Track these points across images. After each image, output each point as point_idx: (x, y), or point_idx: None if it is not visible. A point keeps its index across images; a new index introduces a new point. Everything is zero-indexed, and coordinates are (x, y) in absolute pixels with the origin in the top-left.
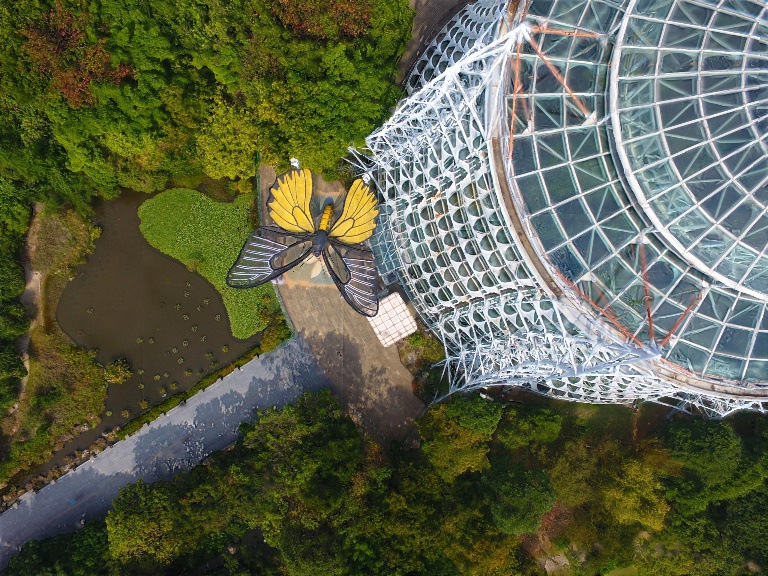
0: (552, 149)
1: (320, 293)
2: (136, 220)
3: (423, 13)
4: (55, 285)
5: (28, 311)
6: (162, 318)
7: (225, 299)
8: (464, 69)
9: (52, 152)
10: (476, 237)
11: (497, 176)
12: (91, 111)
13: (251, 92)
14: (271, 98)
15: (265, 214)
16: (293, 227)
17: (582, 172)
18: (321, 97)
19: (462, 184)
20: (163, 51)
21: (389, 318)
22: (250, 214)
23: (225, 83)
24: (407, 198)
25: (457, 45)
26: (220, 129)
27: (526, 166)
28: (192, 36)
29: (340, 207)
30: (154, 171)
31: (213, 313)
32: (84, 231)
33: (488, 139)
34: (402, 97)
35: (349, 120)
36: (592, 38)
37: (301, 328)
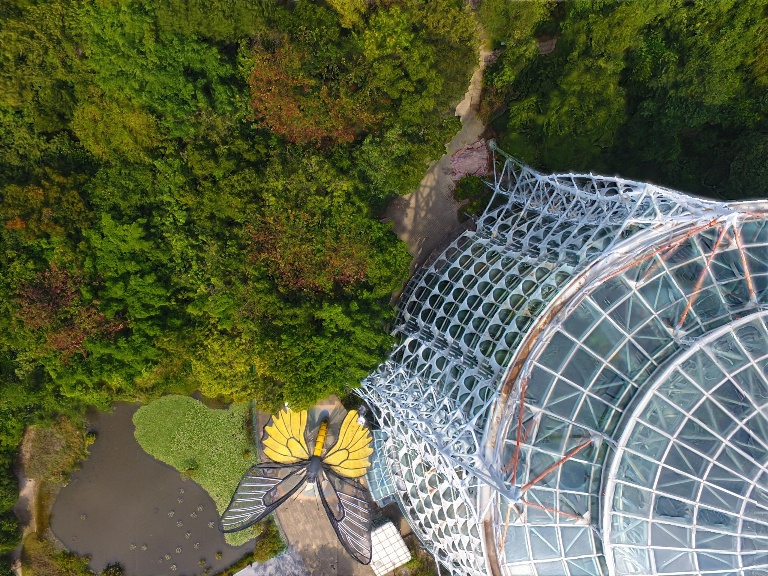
0: (545, 539)
1: (314, 506)
2: (131, 426)
3: (422, 225)
4: (49, 491)
5: (21, 518)
6: (155, 524)
7: (219, 506)
8: (458, 417)
9: (47, 382)
10: (469, 558)
11: (489, 560)
12: (85, 366)
13: (247, 328)
14: (266, 357)
15: (260, 426)
16: (287, 458)
17: (575, 566)
18: (316, 349)
19: (455, 504)
20: (158, 299)
21: (383, 548)
22: (245, 427)
23: (220, 327)
24: (402, 439)
25: (453, 320)
26: (215, 359)
27: (518, 552)
28: (188, 280)
29: (336, 420)
30: (149, 387)
31: (207, 520)
32: (78, 438)
33: (480, 523)
34: (399, 316)
35: (345, 364)
36: (587, 434)
37: (295, 541)
